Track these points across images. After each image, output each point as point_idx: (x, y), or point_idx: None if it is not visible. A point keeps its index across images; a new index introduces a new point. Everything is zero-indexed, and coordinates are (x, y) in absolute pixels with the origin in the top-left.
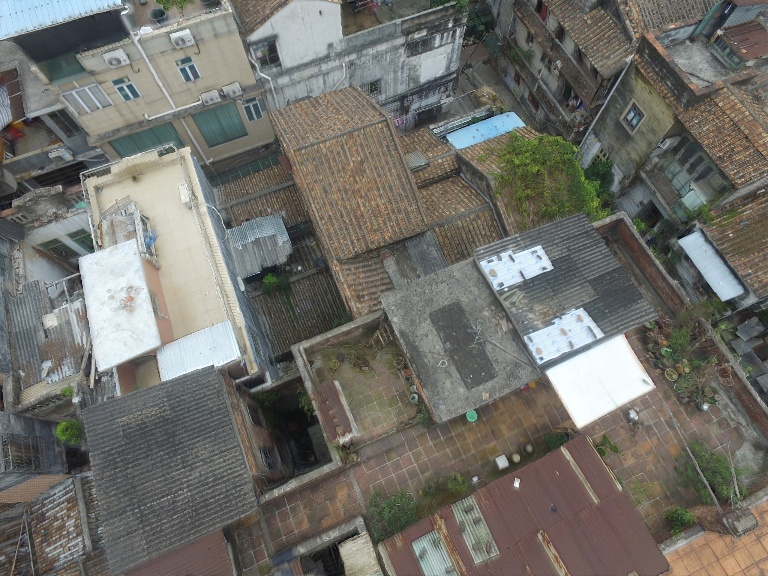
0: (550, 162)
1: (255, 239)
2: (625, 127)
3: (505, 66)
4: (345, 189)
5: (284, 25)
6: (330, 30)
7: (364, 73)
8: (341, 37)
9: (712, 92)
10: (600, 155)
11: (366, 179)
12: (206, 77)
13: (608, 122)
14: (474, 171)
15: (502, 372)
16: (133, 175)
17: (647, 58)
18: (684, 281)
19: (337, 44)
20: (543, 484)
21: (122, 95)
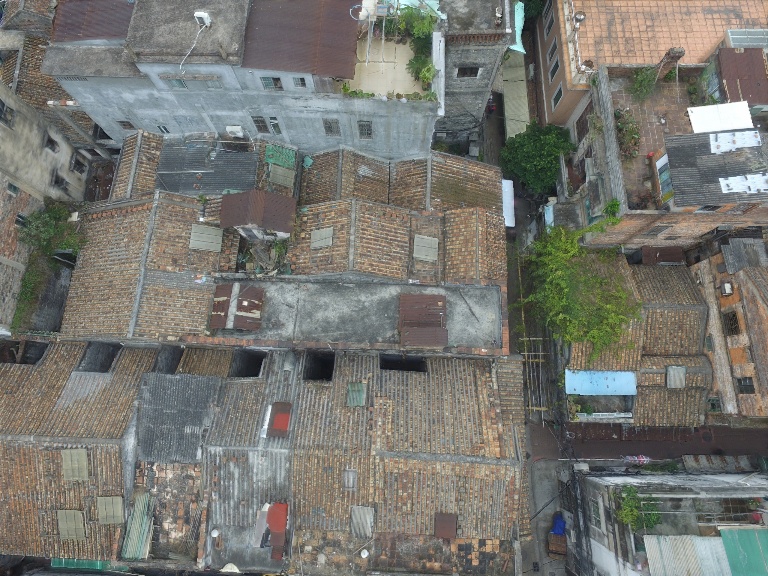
0: (593, 308)
1: None
2: None
3: None
4: None
5: None
6: None
7: None
8: None
9: None
10: None
11: None
12: None
13: None
14: None
15: (766, 142)
16: None
17: None
18: None
19: None
20: (759, 95)
21: None
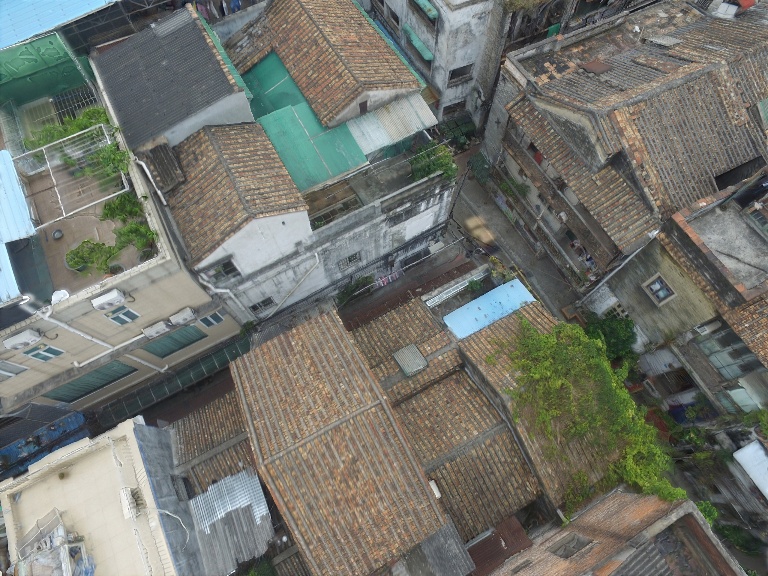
0: (574, 370)
1: (226, 514)
2: (649, 295)
3: (494, 187)
4: (336, 499)
5: (240, 244)
6: (297, 232)
7: (341, 252)
8: (311, 233)
9: (763, 292)
10: (617, 309)
11: (362, 481)
12: (147, 313)
13: (626, 283)
14: (484, 381)
15: None
16: (60, 471)
17: (676, 240)
18: (737, 480)
19: (306, 240)
20: None
21: (39, 358)
